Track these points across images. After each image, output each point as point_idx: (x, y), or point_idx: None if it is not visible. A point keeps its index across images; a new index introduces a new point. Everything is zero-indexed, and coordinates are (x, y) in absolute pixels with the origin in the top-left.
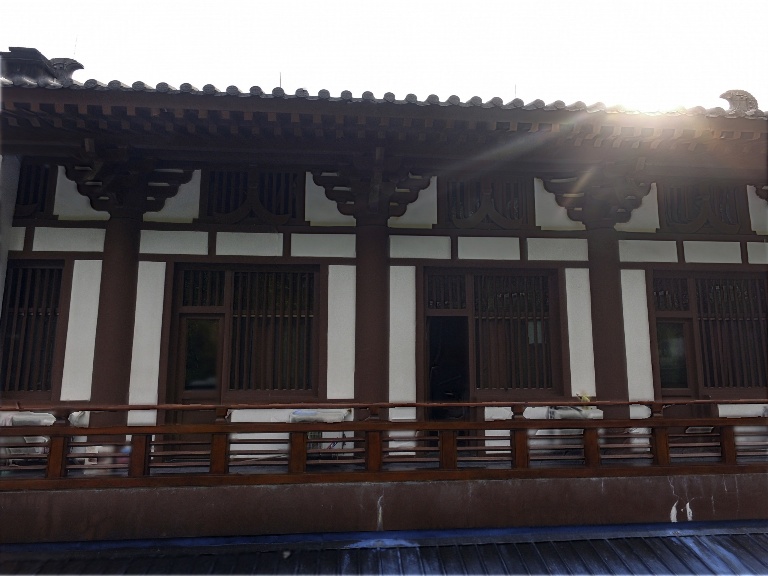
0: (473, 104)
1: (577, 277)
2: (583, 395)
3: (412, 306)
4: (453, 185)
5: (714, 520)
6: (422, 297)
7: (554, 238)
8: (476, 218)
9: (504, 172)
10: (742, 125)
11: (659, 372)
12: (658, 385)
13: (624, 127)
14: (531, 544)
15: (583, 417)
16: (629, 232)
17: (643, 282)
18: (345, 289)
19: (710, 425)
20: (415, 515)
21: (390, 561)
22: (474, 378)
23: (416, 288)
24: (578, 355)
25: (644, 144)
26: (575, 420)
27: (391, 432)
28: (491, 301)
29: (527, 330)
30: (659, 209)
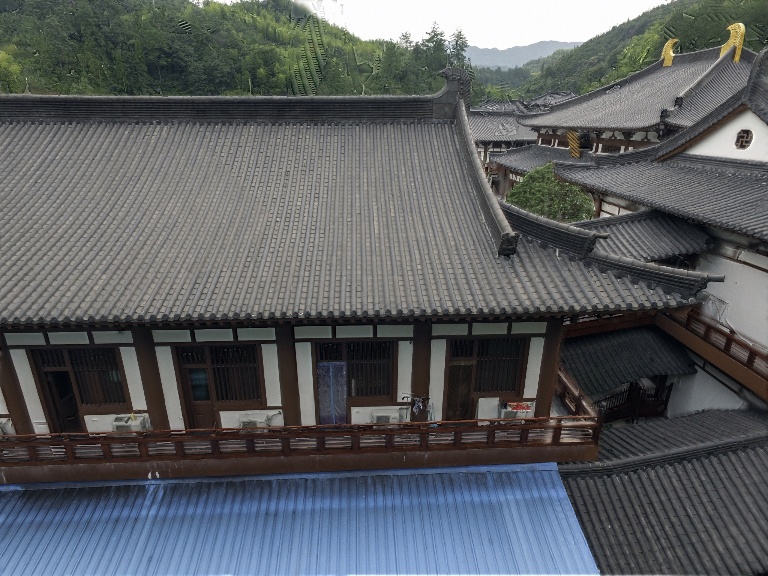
0: None
1: (127, 352)
2: None
3: (29, 370)
4: None
5: None
6: (33, 365)
7: (109, 331)
8: None
9: None
10: None
11: (183, 398)
12: (183, 404)
13: (63, 325)
14: (76, 489)
15: (128, 425)
16: None
17: (169, 353)
18: None
19: None
20: (21, 478)
21: (5, 498)
22: (79, 401)
23: (29, 361)
24: (134, 391)
25: None
26: (95, 441)
27: None
28: None
29: (108, 375)
30: None
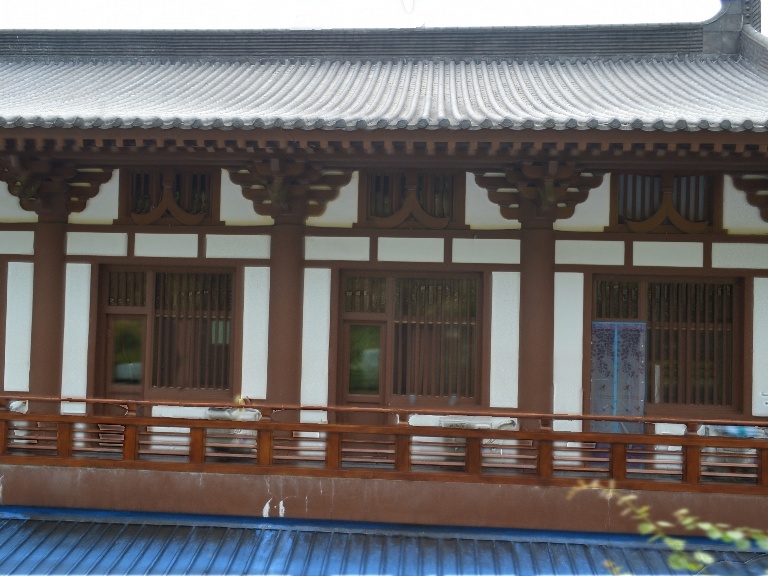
0: (53, 125)
1: (256, 276)
2: (251, 397)
3: (86, 304)
4: (137, 177)
5: (305, 518)
6: (96, 295)
7: (234, 234)
8: (155, 213)
9: (179, 165)
10: (325, 135)
11: (335, 377)
12: (333, 390)
13: (206, 140)
14: (123, 525)
15: (232, 418)
16: (320, 227)
17: (328, 282)
18: (22, 286)
19: (314, 430)
20: (30, 494)
21: None
22: (150, 376)
23: (91, 286)
24: (251, 357)
25: (258, 149)
26: (182, 419)
27: (15, 422)
28: (175, 299)
29: (209, 330)
30: (359, 201)
